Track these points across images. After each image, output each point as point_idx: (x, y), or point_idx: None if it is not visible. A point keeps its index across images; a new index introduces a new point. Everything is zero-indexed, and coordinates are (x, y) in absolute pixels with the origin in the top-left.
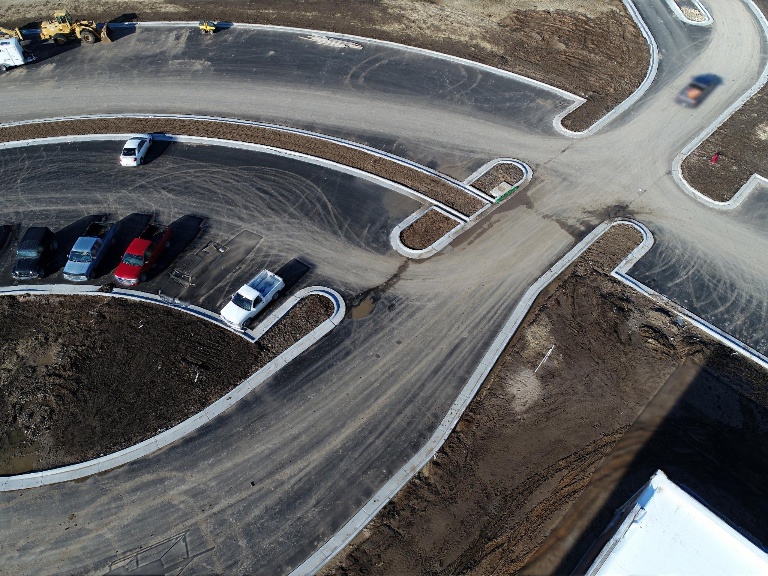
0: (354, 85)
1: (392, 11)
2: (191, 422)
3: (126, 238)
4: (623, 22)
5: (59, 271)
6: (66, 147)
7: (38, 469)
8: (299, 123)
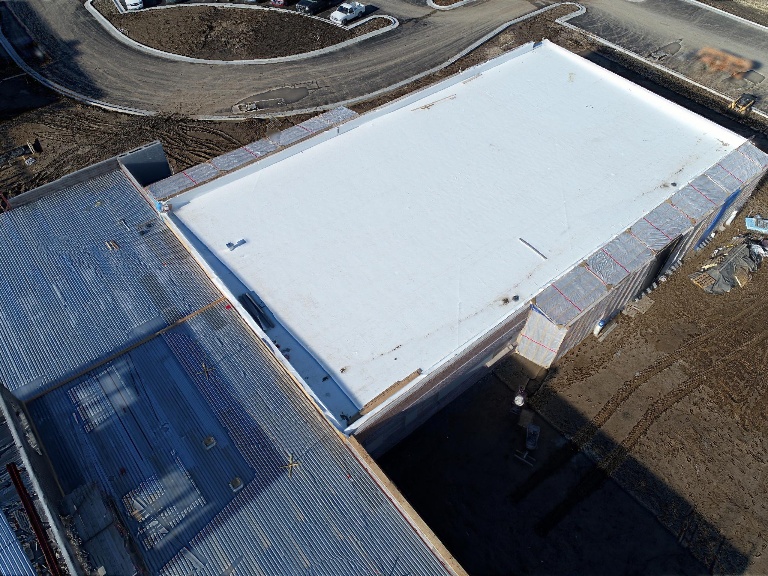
0: None
1: None
2: (316, 52)
3: None
4: None
5: None
6: None
7: None
8: None
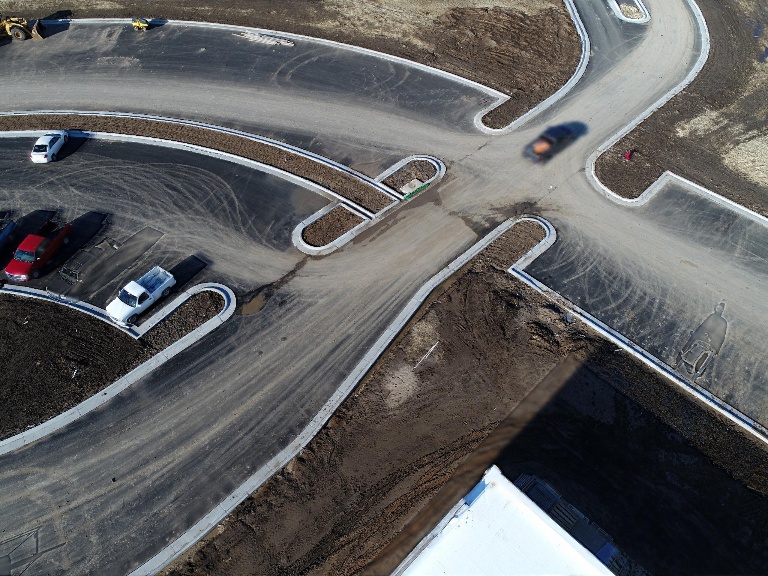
0: (280, 82)
1: (328, 8)
2: (62, 418)
3: (26, 235)
4: (560, 19)
5: None
6: None
7: None
8: (219, 120)
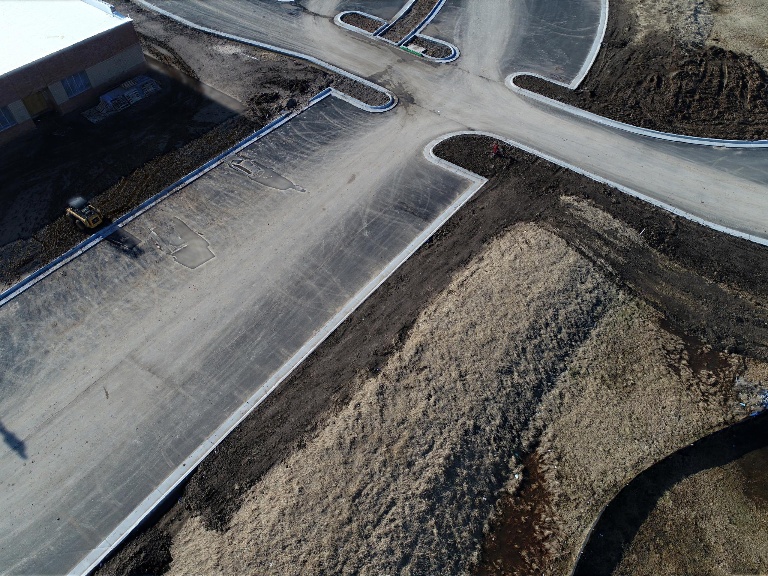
0: None
1: None
2: None
3: None
4: None
5: None
6: None
7: None
8: None
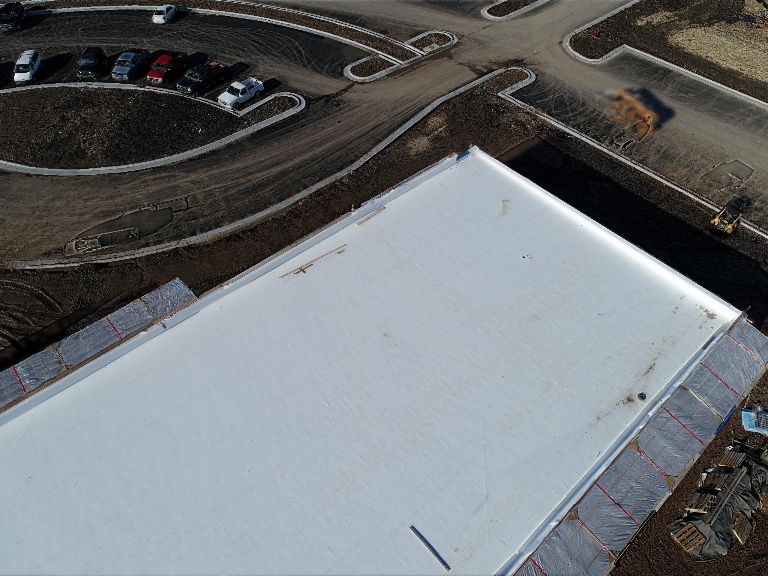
0: None
1: None
2: (194, 152)
3: None
4: None
5: (108, 76)
6: (113, 12)
7: (95, 167)
8: (287, 5)
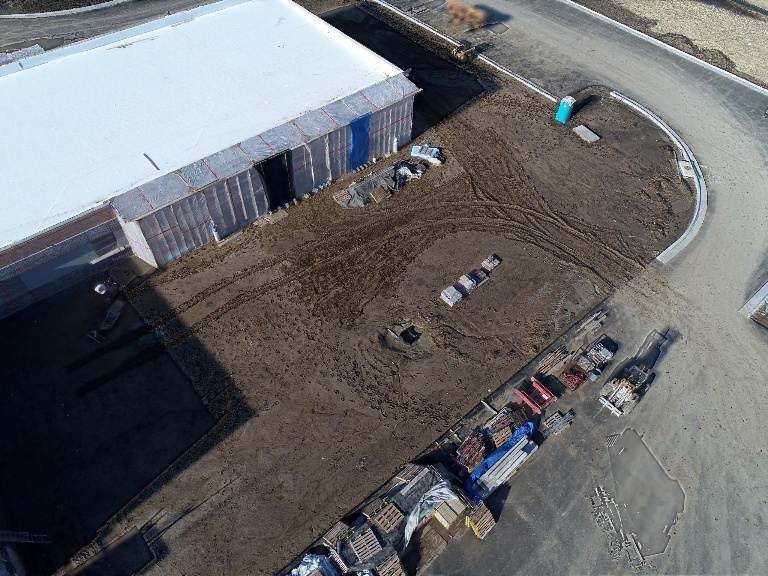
0: None
1: None
2: (90, 8)
3: None
4: None
5: None
6: None
7: None
8: None
